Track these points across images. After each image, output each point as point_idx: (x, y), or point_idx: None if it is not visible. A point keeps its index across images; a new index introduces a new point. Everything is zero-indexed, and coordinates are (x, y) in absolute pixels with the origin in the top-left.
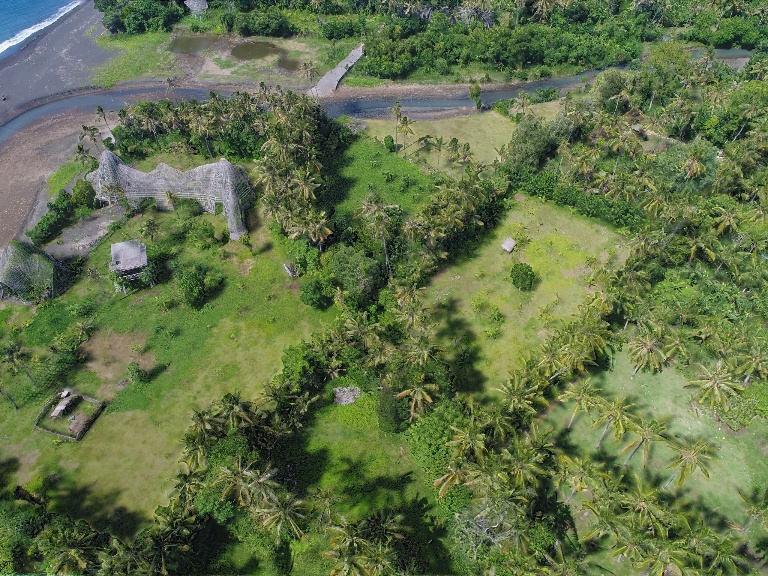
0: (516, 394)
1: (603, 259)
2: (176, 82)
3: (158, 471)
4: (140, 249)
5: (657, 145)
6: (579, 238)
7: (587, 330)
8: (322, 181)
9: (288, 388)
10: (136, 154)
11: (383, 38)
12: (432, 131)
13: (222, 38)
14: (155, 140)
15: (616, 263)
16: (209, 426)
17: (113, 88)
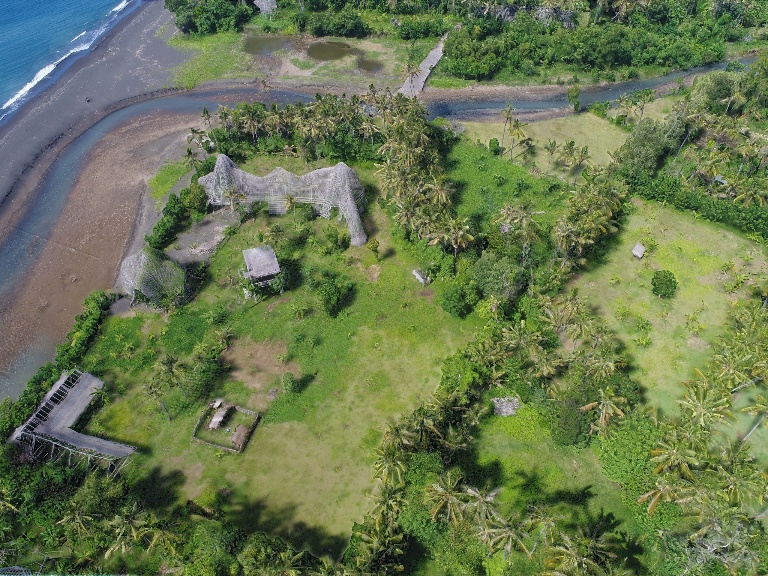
0: (706, 407)
1: (737, 265)
2: (257, 83)
3: (329, 485)
4: (273, 255)
5: (765, 148)
6: (707, 243)
7: (758, 340)
8: None
9: (455, 399)
10: (235, 157)
11: (465, 39)
12: (532, 133)
13: (294, 38)
14: (251, 143)
15: (751, 269)
16: (407, 441)
17: (195, 89)
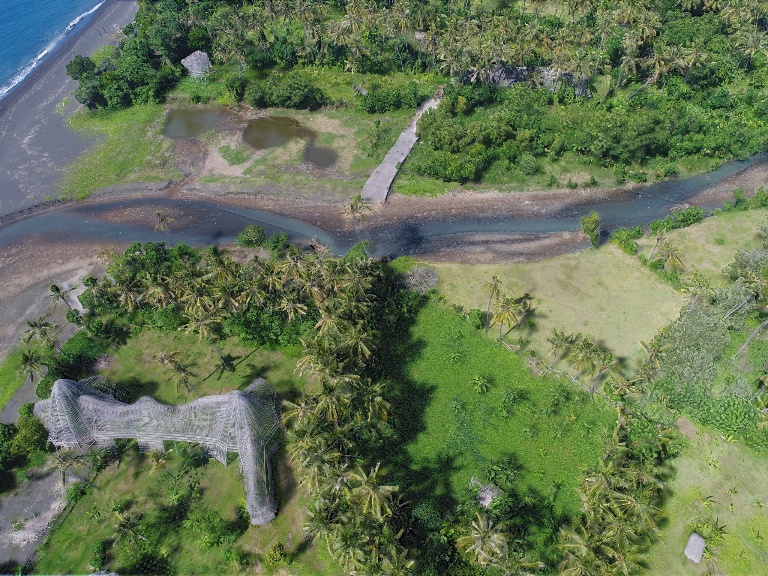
0: None
1: None
2: (171, 189)
3: None
4: None
5: None
6: None
7: None
8: (391, 432)
9: None
10: (113, 334)
11: (445, 121)
12: (531, 285)
13: (230, 111)
14: None
15: None
16: None
17: (88, 200)
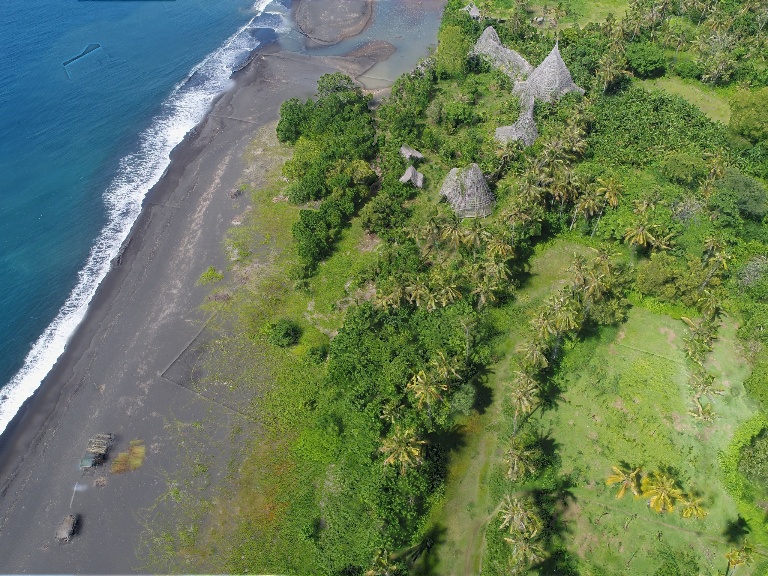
0: None
1: None
2: None
3: None
4: None
5: None
6: None
7: None
8: None
9: None
10: None
11: None
12: None
13: None
14: None
15: None
16: None
17: None
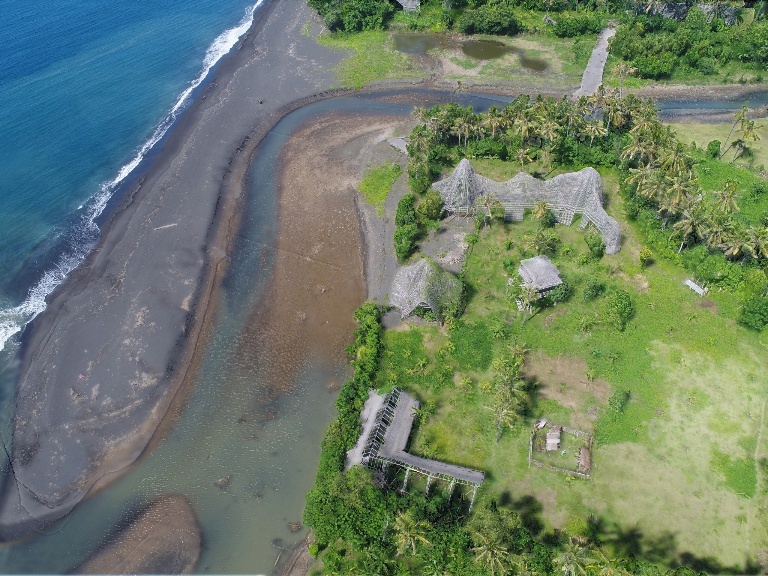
0: None
1: None
2: (425, 83)
3: (698, 512)
4: None
5: None
6: None
7: None
8: None
9: None
10: (442, 161)
11: (635, 36)
12: (740, 135)
13: (443, 36)
14: (452, 145)
15: None
16: None
17: (363, 90)
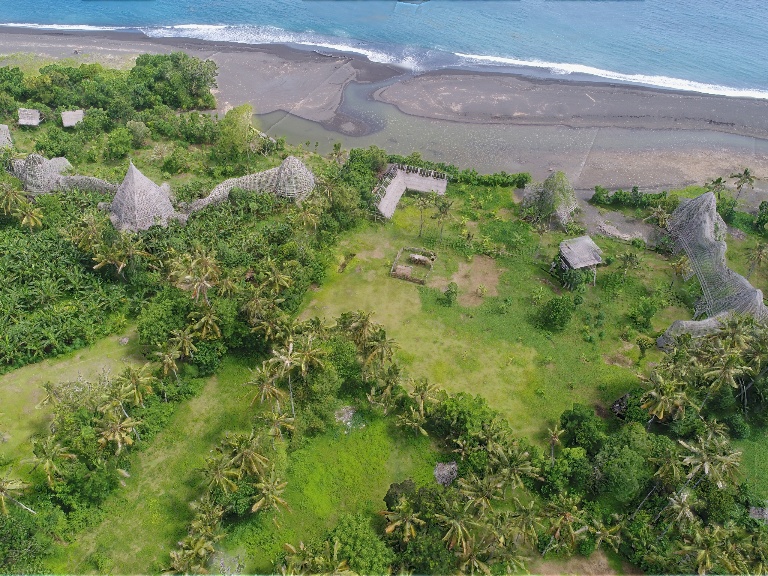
0: None
1: None
2: None
3: None
4: None
5: None
6: None
7: None
8: None
9: (432, 404)
10: (765, 234)
11: None
12: None
13: None
14: None
15: None
16: (354, 324)
17: None
